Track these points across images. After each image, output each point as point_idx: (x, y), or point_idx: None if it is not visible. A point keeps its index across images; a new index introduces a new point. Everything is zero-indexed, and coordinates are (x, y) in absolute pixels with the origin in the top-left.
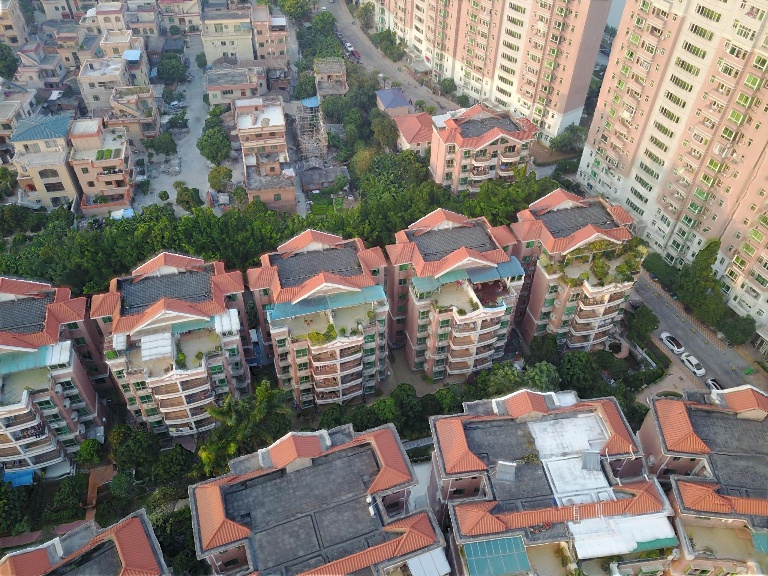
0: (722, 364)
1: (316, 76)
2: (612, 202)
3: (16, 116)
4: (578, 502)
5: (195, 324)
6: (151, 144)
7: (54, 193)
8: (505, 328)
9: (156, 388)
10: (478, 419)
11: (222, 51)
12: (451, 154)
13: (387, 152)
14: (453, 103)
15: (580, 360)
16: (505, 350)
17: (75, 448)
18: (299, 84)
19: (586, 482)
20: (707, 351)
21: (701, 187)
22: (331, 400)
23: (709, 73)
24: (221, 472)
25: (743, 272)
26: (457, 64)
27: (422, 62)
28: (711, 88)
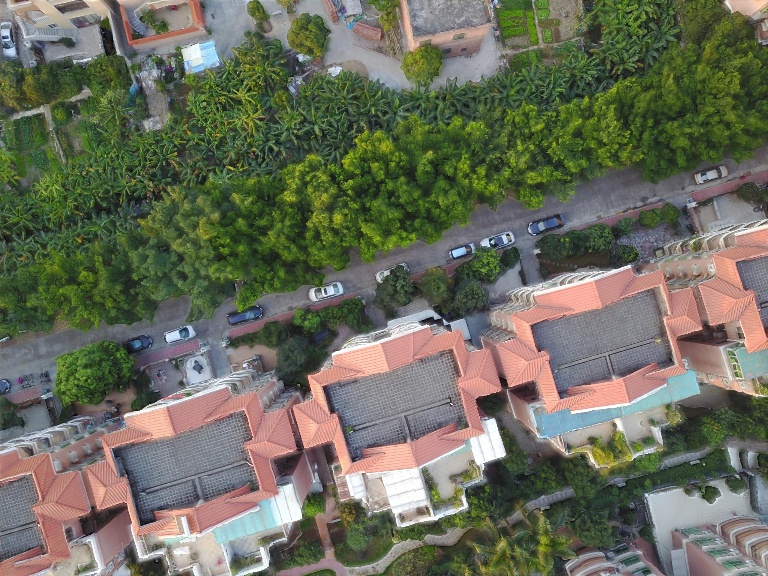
0: None
1: None
2: None
3: None
4: None
5: None
6: None
7: (73, 13)
8: None
9: None
10: None
11: None
12: None
13: None
14: None
15: None
16: None
17: None
18: None
19: None
20: None
21: None
22: None
23: None
24: None
25: None
26: None
27: None
28: None
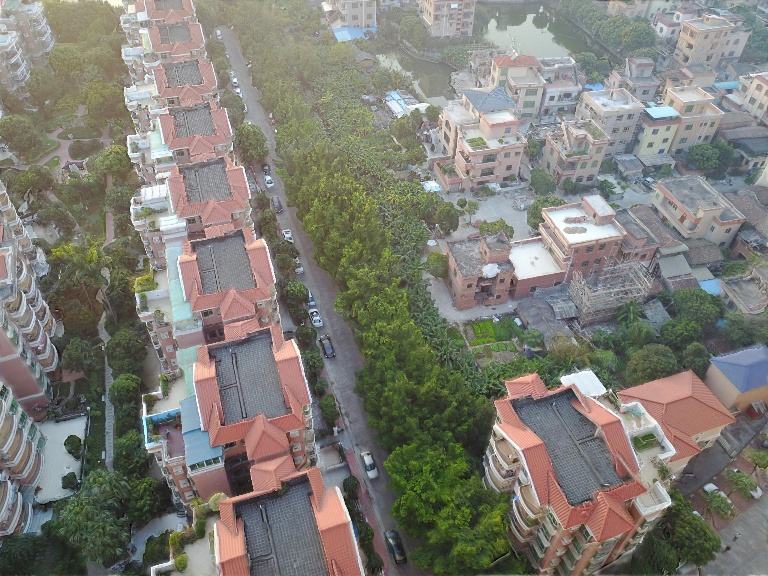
0: None
1: None
2: None
3: (530, 90)
4: None
5: None
6: None
7: None
8: None
9: None
10: None
11: None
12: None
13: None
14: None
15: None
16: None
17: None
18: None
19: None
20: None
21: None
22: None
23: None
24: None
25: None
26: None
27: None
28: None
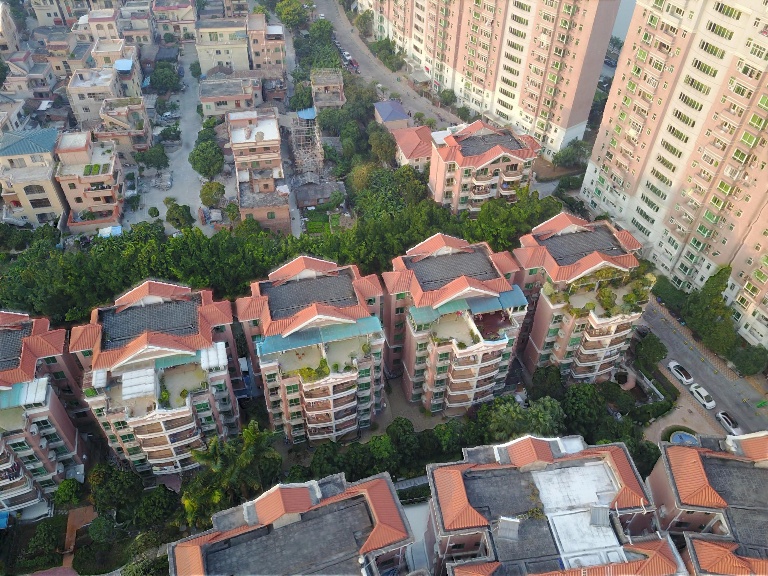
0: (733, 396)
1: (313, 87)
2: (617, 221)
3: (2, 128)
4: (586, 563)
5: (180, 359)
6: (142, 158)
7: (40, 209)
8: (507, 360)
9: (138, 428)
10: (479, 468)
11: (217, 60)
12: (451, 172)
13: (385, 167)
14: (453, 115)
15: (585, 394)
16: (507, 381)
17: (53, 488)
18: (295, 95)
19: (594, 540)
20: (717, 381)
21: (711, 210)
22: (324, 435)
23: (720, 93)
24: (205, 522)
25: (755, 299)
26: (457, 75)
27: (422, 72)
28: (722, 108)
